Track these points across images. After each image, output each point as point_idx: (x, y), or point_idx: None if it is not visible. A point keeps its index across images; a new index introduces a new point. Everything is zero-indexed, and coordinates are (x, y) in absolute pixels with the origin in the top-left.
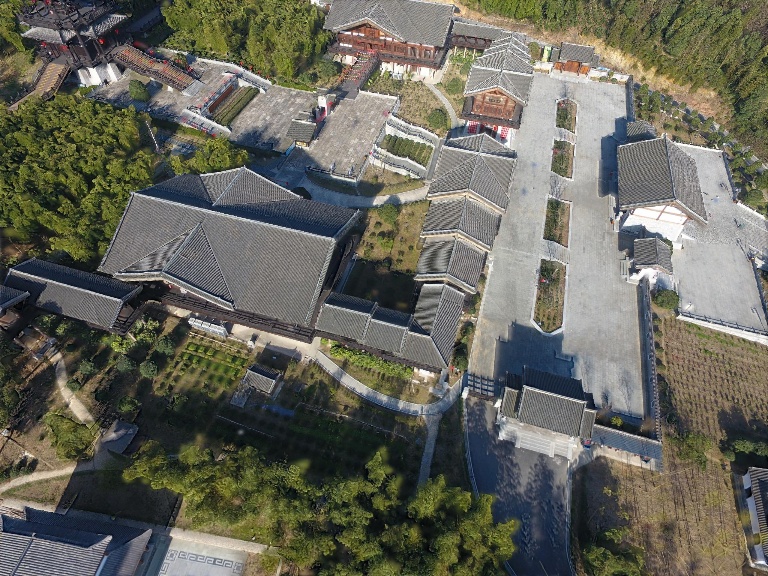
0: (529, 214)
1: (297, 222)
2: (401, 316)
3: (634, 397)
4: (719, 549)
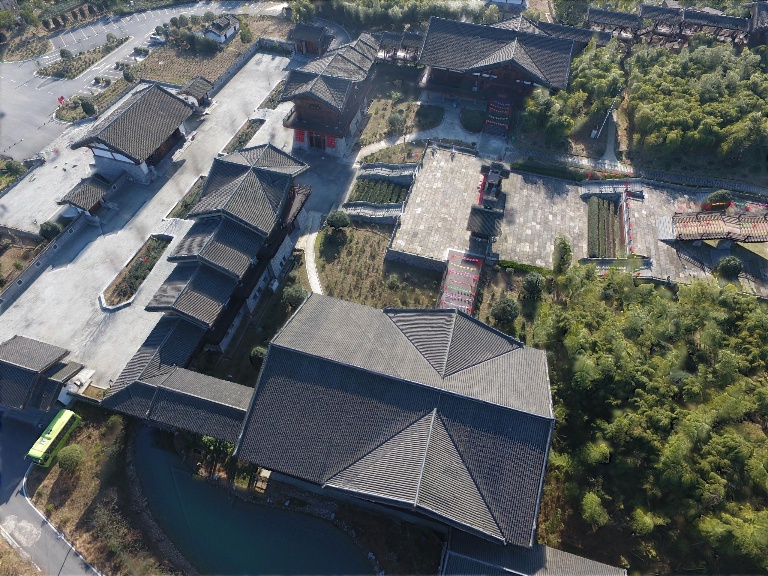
0: (268, 137)
1: (458, 34)
2: (387, 41)
3: (257, 59)
4: (252, 30)
